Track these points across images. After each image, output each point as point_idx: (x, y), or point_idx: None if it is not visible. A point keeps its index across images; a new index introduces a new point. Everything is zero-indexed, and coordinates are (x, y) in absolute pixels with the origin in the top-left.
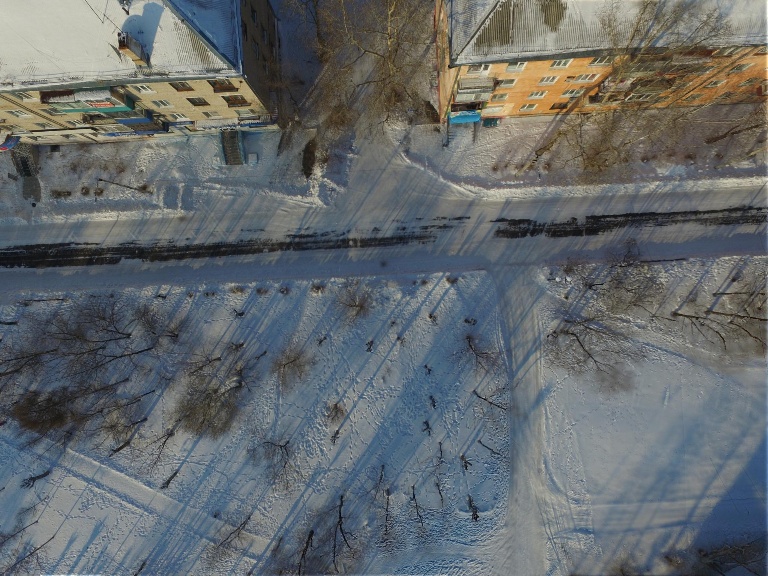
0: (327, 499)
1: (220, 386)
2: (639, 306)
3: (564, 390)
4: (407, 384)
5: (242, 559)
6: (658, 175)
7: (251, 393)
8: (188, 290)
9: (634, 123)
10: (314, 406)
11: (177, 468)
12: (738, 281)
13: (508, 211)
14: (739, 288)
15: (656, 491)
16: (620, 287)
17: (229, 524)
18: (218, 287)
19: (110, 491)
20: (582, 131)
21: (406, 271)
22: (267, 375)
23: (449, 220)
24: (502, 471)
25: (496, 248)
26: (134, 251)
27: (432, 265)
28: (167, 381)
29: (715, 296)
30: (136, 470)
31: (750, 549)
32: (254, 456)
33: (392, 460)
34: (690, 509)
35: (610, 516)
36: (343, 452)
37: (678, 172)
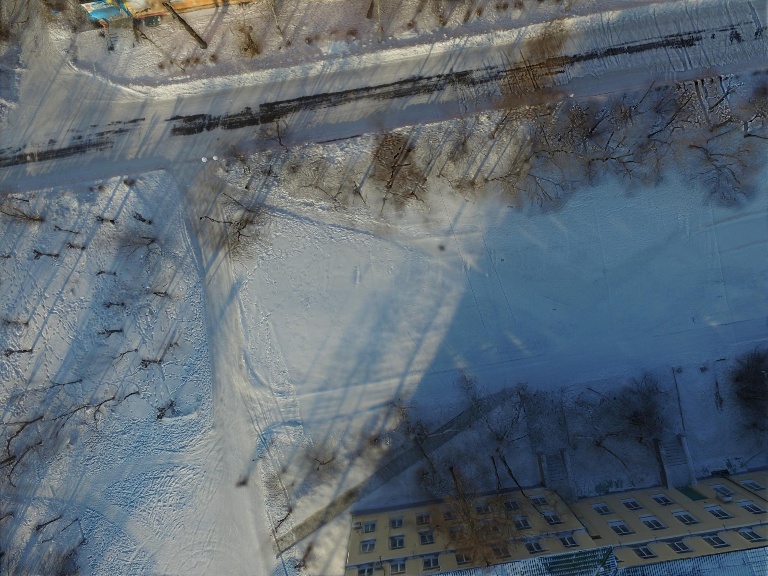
0: None
1: None
2: None
3: (255, 281)
4: (97, 294)
5: None
6: (323, 55)
7: None
8: None
9: (296, 7)
10: (5, 327)
11: None
12: (414, 151)
13: (181, 108)
14: (416, 158)
15: (359, 373)
16: (299, 171)
17: None
18: None
19: None
20: (246, 20)
21: (85, 179)
22: None
23: (124, 124)
24: (203, 371)
25: (174, 146)
26: None
27: (111, 171)
28: None
29: None
30: None
31: (460, 421)
32: None
33: (89, 373)
34: (396, 388)
35: (317, 405)
36: (38, 371)
37: (341, 49)
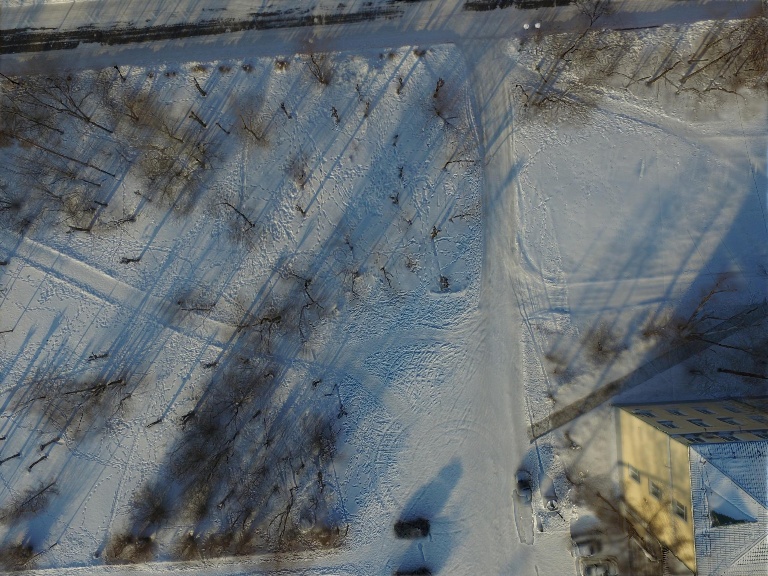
0: (294, 283)
1: (182, 169)
2: (612, 74)
3: (537, 165)
4: (375, 163)
5: (207, 348)
6: None
7: (214, 171)
8: (148, 71)
9: None
10: (280, 188)
11: (139, 256)
12: (713, 47)
13: None
14: (714, 54)
15: (633, 267)
16: (592, 56)
17: (194, 312)
18: (179, 67)
19: (70, 281)
20: None
21: (373, 47)
22: (231, 156)
23: None
24: (474, 251)
25: (465, 21)
26: (92, 35)
27: (399, 40)
28: (127, 163)
29: (690, 63)
30: (97, 258)
31: (730, 325)
32: (218, 240)
33: (361, 241)
34: (668, 285)
35: (586, 295)
36: (310, 234)
37: None
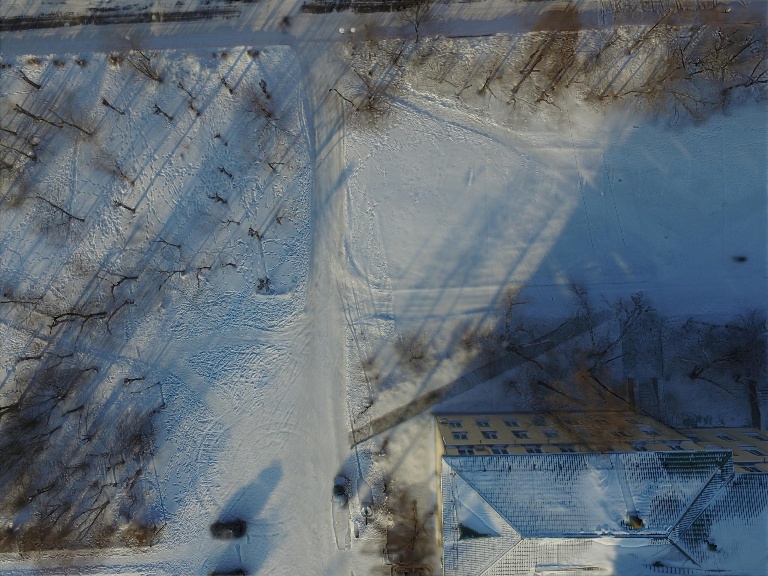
0: None
1: (15, 162)
2: (443, 81)
3: (366, 170)
4: (206, 162)
5: (33, 341)
6: None
7: (42, 164)
8: None
9: None
10: (111, 183)
11: None
12: (545, 57)
13: None
14: (546, 65)
15: (458, 276)
16: (425, 63)
17: (21, 304)
18: (15, 59)
19: None
20: None
21: (208, 46)
22: (63, 150)
23: None
24: (302, 254)
25: (301, 24)
26: None
27: (235, 40)
28: None
29: (522, 73)
30: None
31: None
32: (47, 234)
33: (189, 240)
34: (493, 295)
35: (411, 302)
36: (139, 231)
37: None
